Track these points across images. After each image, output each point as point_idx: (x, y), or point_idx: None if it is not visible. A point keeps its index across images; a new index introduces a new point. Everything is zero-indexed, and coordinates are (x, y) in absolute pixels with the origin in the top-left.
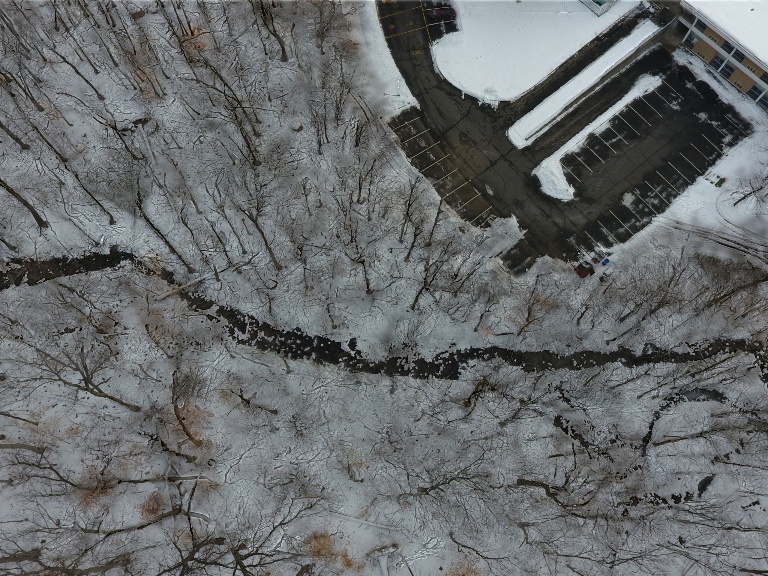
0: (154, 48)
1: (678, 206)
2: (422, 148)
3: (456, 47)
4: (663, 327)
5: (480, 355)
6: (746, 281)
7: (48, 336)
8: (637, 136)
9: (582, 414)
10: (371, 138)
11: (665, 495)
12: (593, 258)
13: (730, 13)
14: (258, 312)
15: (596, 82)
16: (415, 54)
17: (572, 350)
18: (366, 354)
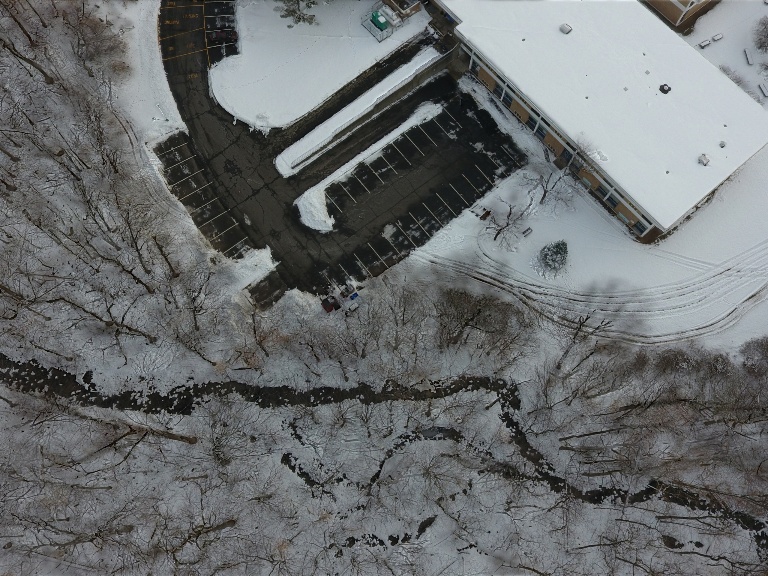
0: None
1: (438, 239)
2: (185, 175)
3: (233, 71)
4: (406, 364)
5: (217, 390)
6: (497, 317)
7: None
8: (408, 166)
9: (312, 452)
10: (129, 165)
11: (382, 536)
12: (341, 292)
13: (500, 43)
14: None
15: (370, 110)
16: (191, 77)
17: (311, 386)
18: (100, 387)
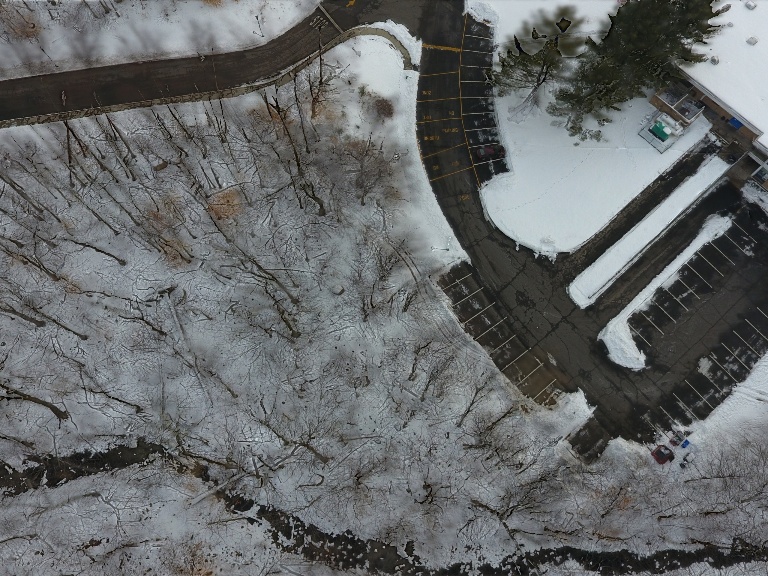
0: (180, 210)
1: (760, 373)
2: (476, 311)
3: (507, 190)
4: (752, 519)
5: (551, 557)
6: None
7: (72, 551)
8: (709, 289)
9: None
10: None
11: None
12: (672, 441)
13: None
14: (304, 513)
15: (662, 229)
16: (463, 199)
17: (653, 549)
18: (425, 560)
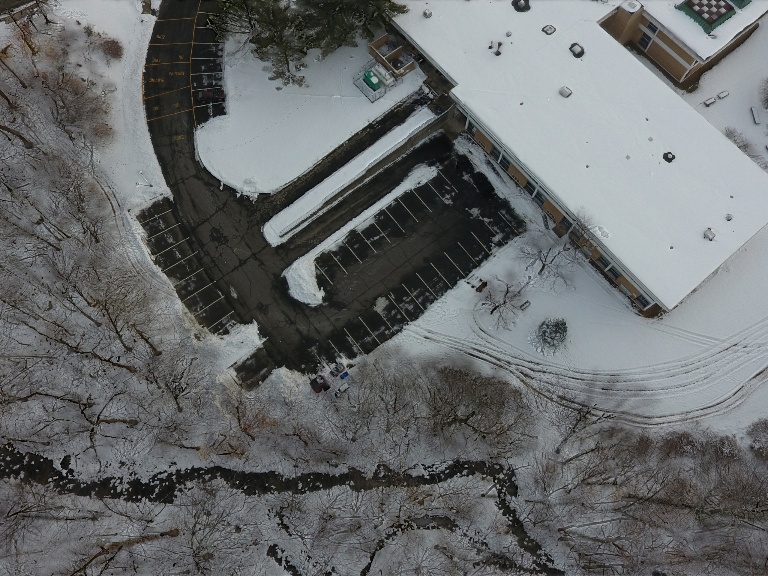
0: None
1: (432, 313)
2: (169, 245)
3: (220, 132)
4: (398, 447)
5: (201, 476)
6: (493, 397)
7: None
8: (402, 233)
9: (300, 543)
10: (110, 235)
11: None
12: (330, 371)
13: (497, 107)
14: None
15: (362, 175)
16: (177, 139)
17: (299, 471)
18: (79, 473)
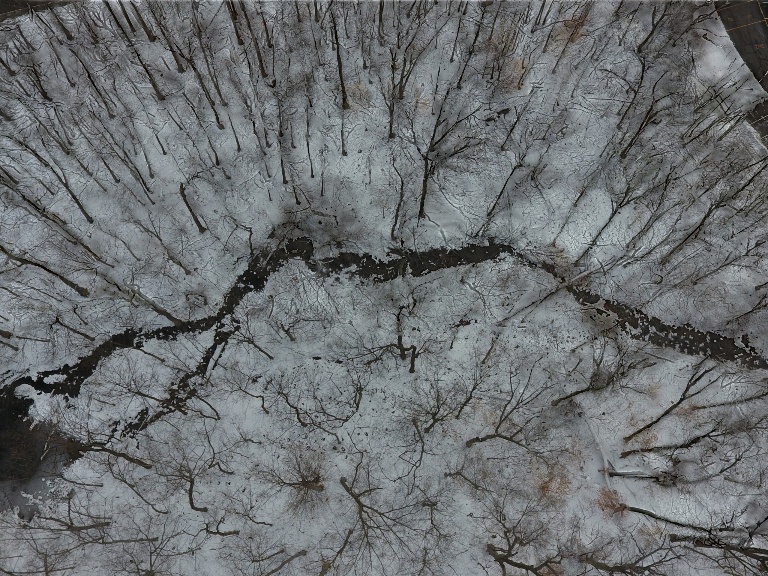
0: (520, 37)
1: None
2: None
3: None
4: None
5: None
6: None
7: (445, 328)
8: None
9: None
10: None
11: None
12: None
13: None
14: (647, 307)
15: None
16: (758, 48)
17: None
18: (761, 351)
